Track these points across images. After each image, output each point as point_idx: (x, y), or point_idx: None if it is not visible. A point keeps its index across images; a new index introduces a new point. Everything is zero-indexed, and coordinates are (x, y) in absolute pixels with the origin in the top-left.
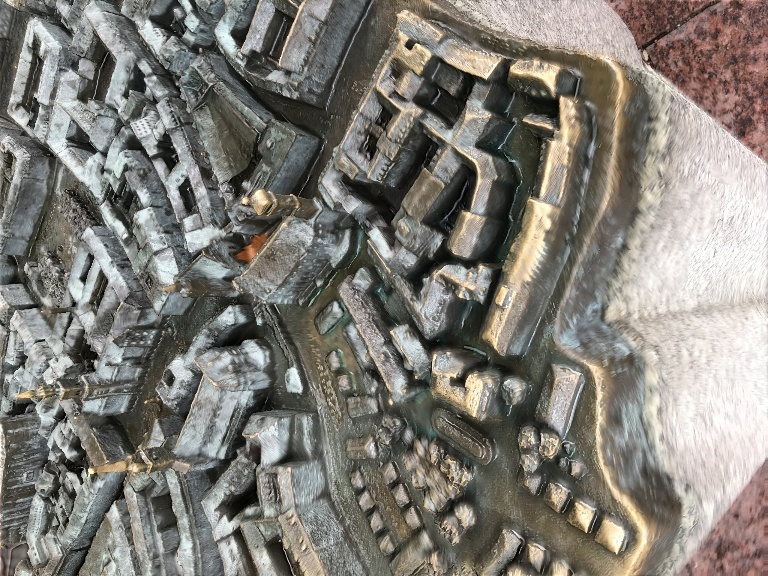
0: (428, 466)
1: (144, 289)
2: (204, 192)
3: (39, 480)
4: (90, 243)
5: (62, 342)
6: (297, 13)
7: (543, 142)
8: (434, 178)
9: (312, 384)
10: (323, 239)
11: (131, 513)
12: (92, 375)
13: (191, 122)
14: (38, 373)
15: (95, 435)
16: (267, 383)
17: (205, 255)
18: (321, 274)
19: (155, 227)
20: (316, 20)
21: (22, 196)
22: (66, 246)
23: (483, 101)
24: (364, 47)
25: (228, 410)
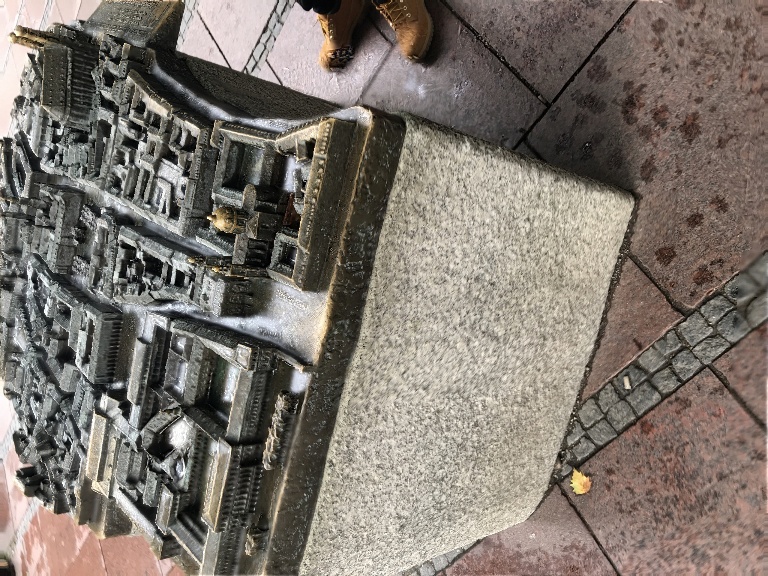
0: (1, 262)
1: None
2: None
3: None
4: None
5: None
6: (5, 378)
7: None
8: None
9: None
10: None
11: None
12: None
13: None
14: None
15: None
16: None
17: None
18: None
19: None
20: None
21: None
22: None
23: None
24: None
25: None
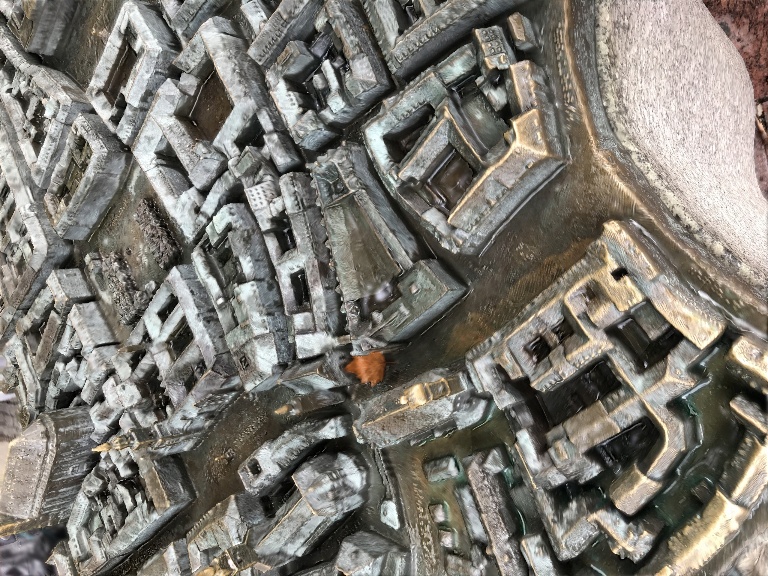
0: None
1: (237, 367)
2: (321, 293)
3: (86, 481)
4: (176, 287)
5: (128, 366)
6: (483, 176)
7: (748, 435)
8: (610, 420)
9: (408, 521)
10: (459, 411)
11: (193, 569)
12: (165, 423)
13: (313, 204)
14: (96, 381)
15: (156, 470)
16: (360, 504)
17: (319, 374)
18: (441, 426)
19: (258, 307)
20: (501, 185)
21: (93, 189)
22: (135, 251)
23: (687, 363)
24: (541, 210)
25: (316, 521)
